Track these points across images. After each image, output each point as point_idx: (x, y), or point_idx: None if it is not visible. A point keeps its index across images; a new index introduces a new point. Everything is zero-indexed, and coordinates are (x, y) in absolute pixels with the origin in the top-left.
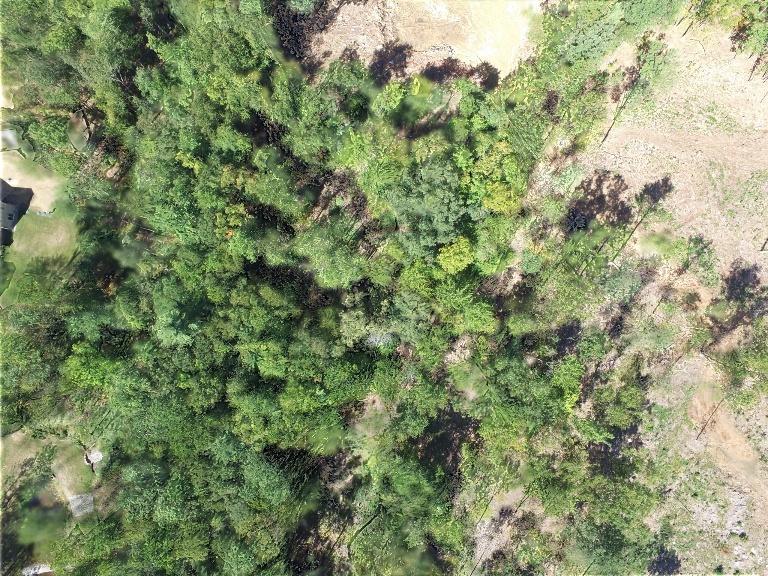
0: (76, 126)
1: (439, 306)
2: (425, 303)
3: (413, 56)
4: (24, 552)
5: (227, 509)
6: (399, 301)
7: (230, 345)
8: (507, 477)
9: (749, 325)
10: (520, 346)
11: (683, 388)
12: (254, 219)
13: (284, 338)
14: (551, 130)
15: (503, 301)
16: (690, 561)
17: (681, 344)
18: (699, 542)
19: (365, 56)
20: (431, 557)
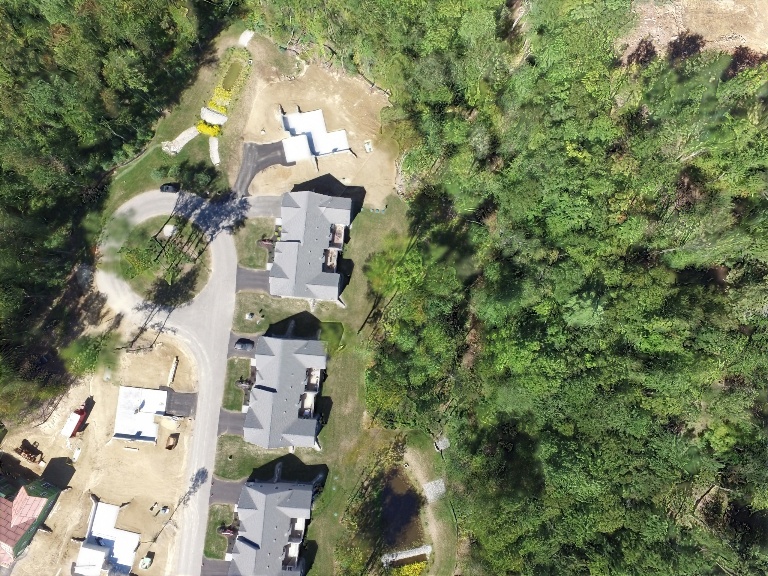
0: None
1: None
2: None
3: (706, 46)
4: (381, 540)
5: (634, 481)
6: None
7: (620, 325)
8: None
9: None
10: None
11: None
12: None
13: (681, 315)
14: None
15: None
16: None
17: None
18: None
19: (660, 47)
20: None
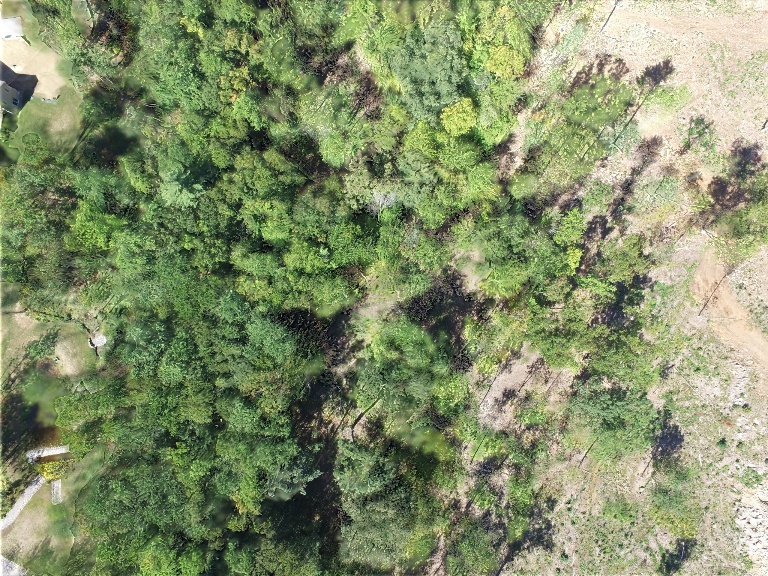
0: (80, 16)
1: (442, 167)
2: (428, 164)
3: None
4: (28, 435)
5: (231, 370)
6: (402, 163)
7: (234, 210)
8: (510, 358)
9: (750, 202)
10: (523, 208)
11: (685, 265)
12: (258, 87)
13: (288, 199)
14: (552, 17)
15: (505, 185)
16: (693, 435)
17: (683, 222)
18: (702, 416)
19: None
20: (434, 438)
